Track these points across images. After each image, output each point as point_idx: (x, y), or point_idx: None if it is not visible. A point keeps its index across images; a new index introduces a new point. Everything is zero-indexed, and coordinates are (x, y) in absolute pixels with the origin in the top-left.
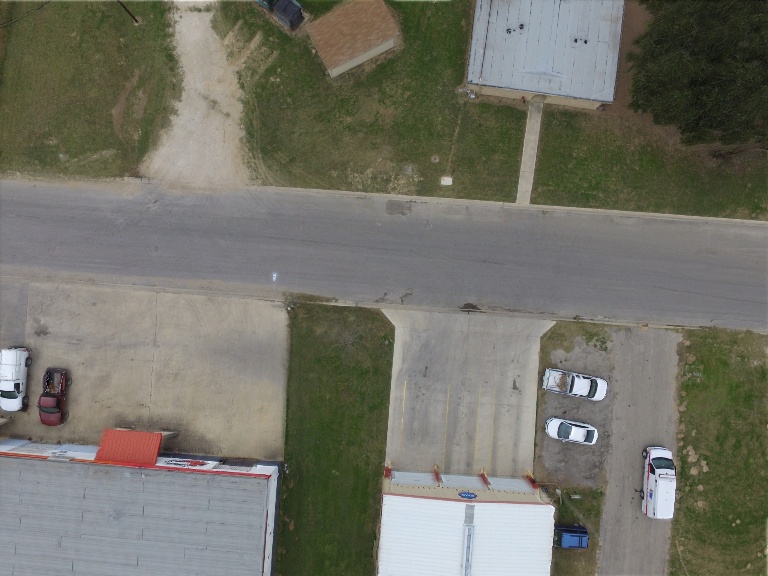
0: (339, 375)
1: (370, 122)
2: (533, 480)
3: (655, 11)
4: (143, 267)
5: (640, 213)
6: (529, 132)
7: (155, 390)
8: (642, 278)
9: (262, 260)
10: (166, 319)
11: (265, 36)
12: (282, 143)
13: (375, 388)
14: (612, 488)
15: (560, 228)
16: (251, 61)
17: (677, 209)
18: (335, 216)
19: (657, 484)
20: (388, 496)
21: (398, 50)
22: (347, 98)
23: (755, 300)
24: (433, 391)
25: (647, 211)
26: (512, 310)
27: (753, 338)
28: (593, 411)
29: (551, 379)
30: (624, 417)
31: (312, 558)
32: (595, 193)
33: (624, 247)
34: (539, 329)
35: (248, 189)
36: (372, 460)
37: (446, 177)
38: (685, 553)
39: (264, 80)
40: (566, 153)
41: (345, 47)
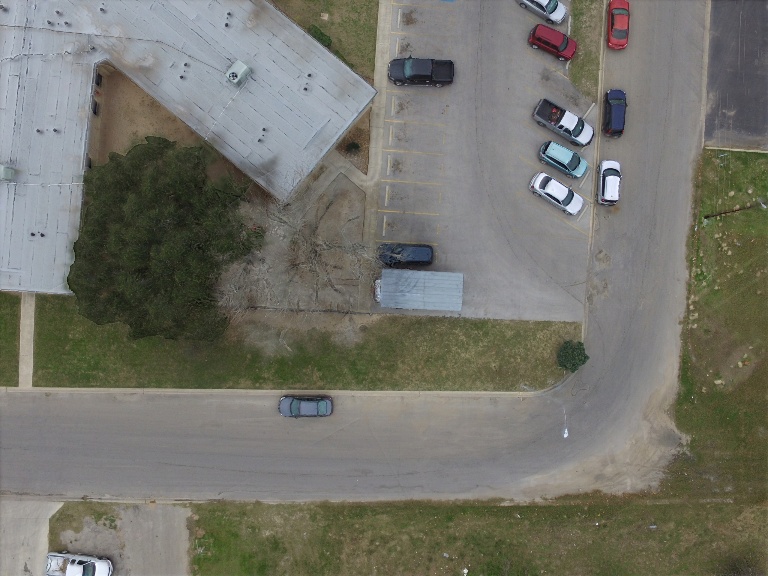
0: None
1: None
2: None
3: None
4: None
5: (143, 389)
6: (24, 316)
7: None
8: (147, 455)
9: None
10: None
11: None
12: None
13: None
14: None
15: (63, 409)
16: None
17: (179, 384)
18: None
19: None
20: None
21: None
22: None
23: (262, 470)
24: None
25: (149, 387)
26: (21, 493)
27: (262, 509)
28: None
29: (54, 563)
30: None
31: None
32: (95, 373)
33: (127, 425)
34: (47, 511)
35: None
36: None
37: None
38: None
39: None
40: (62, 335)
41: None
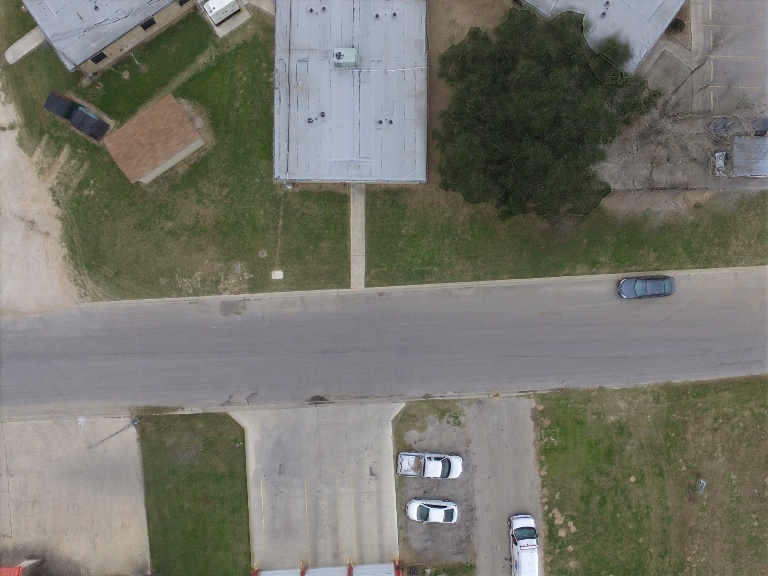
0: (194, 483)
1: (191, 224)
2: (396, 566)
3: (455, 83)
4: None
5: (478, 282)
6: (354, 215)
7: (14, 520)
8: (487, 348)
9: (102, 378)
10: (15, 448)
11: (73, 149)
12: (105, 257)
13: (232, 492)
14: (481, 560)
15: (398, 308)
16: (63, 176)
17: (515, 274)
18: (169, 324)
19: (519, 556)
20: None
21: (210, 147)
22: (165, 203)
23: (605, 356)
24: (290, 488)
25: (485, 279)
26: (360, 397)
27: (607, 394)
28: (453, 487)
29: (405, 463)
30: (485, 489)
31: None
32: (430, 268)
33: (466, 319)
34: (389, 413)
35: (78, 307)
36: (238, 563)
37: (276, 271)
38: None
39: (78, 194)
40: (395, 231)
41: (146, 157)
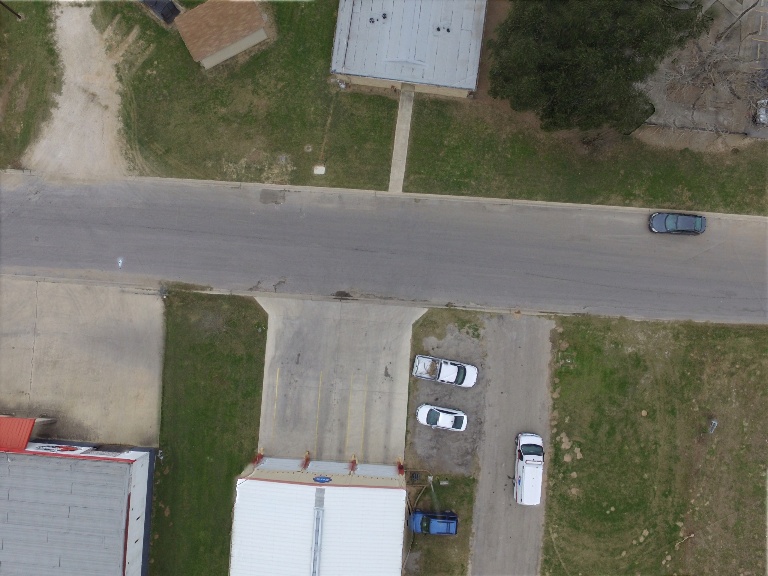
0: (213, 362)
1: (244, 113)
2: (401, 466)
3: None
4: (24, 257)
5: (513, 200)
6: (400, 121)
7: (35, 377)
8: (514, 265)
9: None
10: (46, 308)
11: (142, 30)
12: (158, 134)
13: (248, 375)
14: (485, 475)
15: (432, 216)
16: (129, 54)
17: (549, 196)
18: (210, 206)
19: (524, 470)
20: (242, 480)
21: (271, 41)
22: (221, 89)
23: (629, 287)
24: (305, 378)
25: (520, 198)
26: (384, 297)
27: (627, 325)
28: (465, 398)
29: (421, 366)
30: (497, 404)
31: (186, 543)
32: (467, 181)
33: (496, 234)
34: (411, 316)
35: (126, 180)
36: (245, 446)
37: (319, 166)
38: (559, 540)
39: (141, 73)
40: (437, 141)
41: (212, 39)
